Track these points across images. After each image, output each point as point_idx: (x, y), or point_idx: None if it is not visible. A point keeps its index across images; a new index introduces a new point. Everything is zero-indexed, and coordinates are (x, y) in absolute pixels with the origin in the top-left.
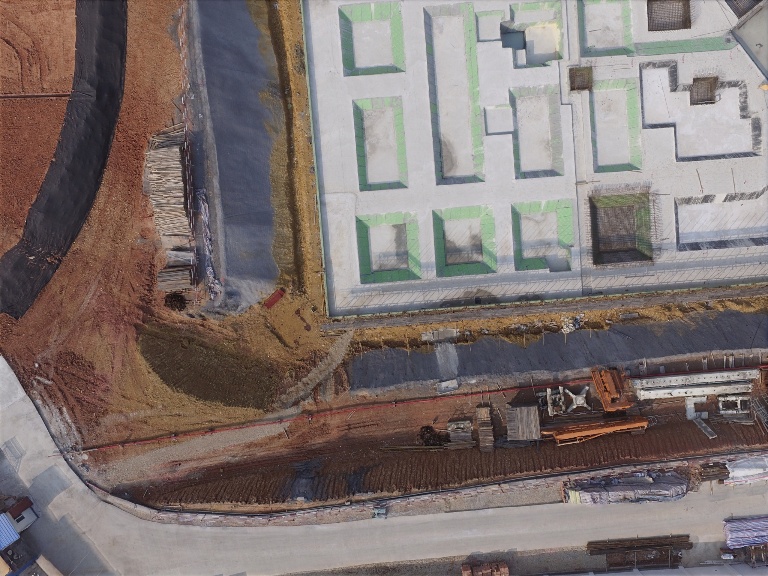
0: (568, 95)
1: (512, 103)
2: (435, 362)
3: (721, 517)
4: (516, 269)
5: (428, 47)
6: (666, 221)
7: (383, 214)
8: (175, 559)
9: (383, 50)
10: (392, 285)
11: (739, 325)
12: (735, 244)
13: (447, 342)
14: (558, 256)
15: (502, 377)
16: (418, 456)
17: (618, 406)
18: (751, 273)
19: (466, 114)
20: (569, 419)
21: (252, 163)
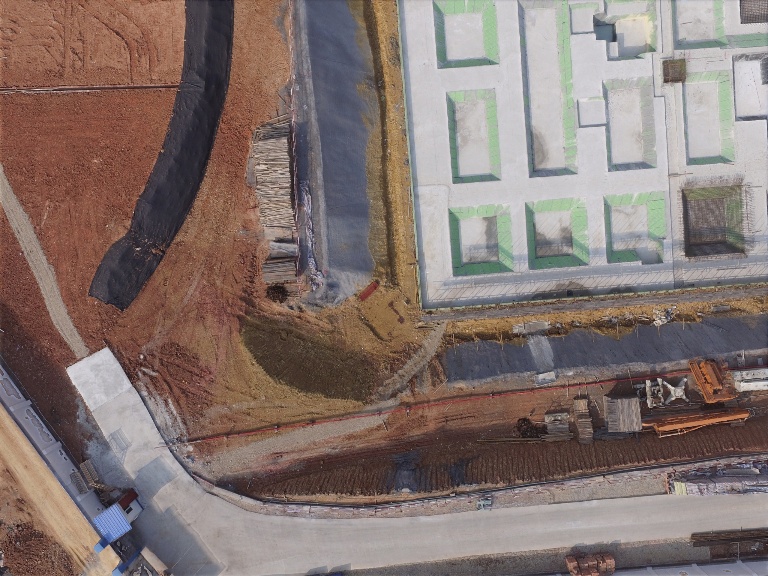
0: (661, 87)
1: (605, 95)
2: (529, 354)
3: None
4: (608, 261)
5: (521, 39)
6: (758, 213)
7: (476, 206)
8: (279, 551)
9: (475, 43)
10: (484, 277)
11: None
12: None
13: (539, 334)
14: (648, 249)
15: (599, 369)
16: (516, 448)
17: (720, 398)
18: None
19: (558, 107)
20: (666, 411)
21: (351, 155)
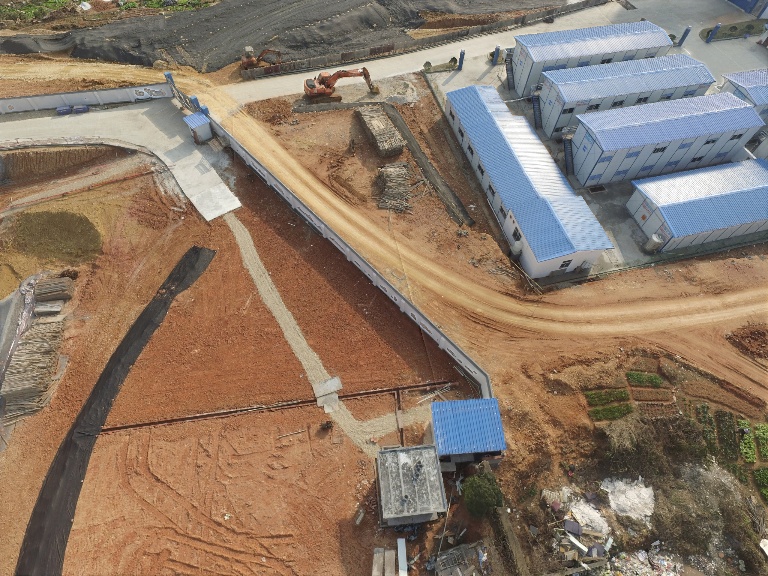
0: None
1: None
2: None
3: None
4: None
5: None
6: None
7: None
8: (100, 122)
9: None
10: None
11: None
12: None
13: None
14: None
15: None
16: None
17: None
18: None
19: None
20: None
21: None
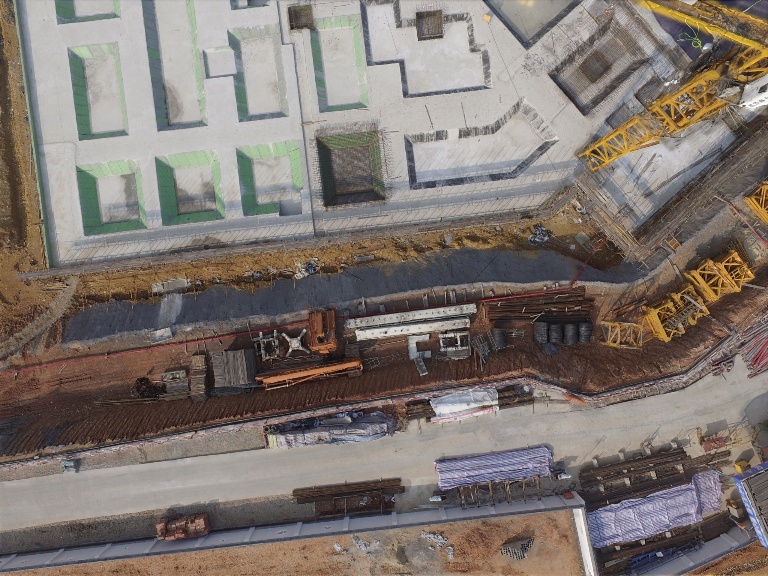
0: (290, 35)
1: (234, 45)
2: (157, 312)
3: (432, 458)
4: (245, 214)
5: None
6: (397, 159)
7: (105, 163)
8: None
9: None
10: (117, 236)
11: (470, 261)
12: (472, 180)
13: (176, 292)
14: (294, 201)
15: (218, 323)
16: (130, 409)
17: None
18: (488, 209)
19: (190, 59)
20: (289, 364)
21: None
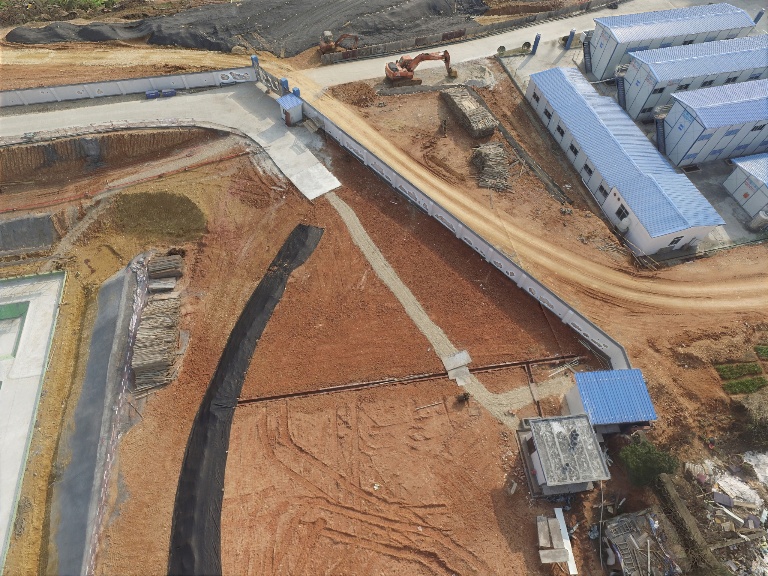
0: None
1: None
2: None
3: None
4: None
5: None
6: None
7: None
8: (189, 106)
9: None
10: None
11: None
12: None
13: None
14: None
15: None
16: (5, 178)
17: None
18: None
19: None
20: None
21: None
